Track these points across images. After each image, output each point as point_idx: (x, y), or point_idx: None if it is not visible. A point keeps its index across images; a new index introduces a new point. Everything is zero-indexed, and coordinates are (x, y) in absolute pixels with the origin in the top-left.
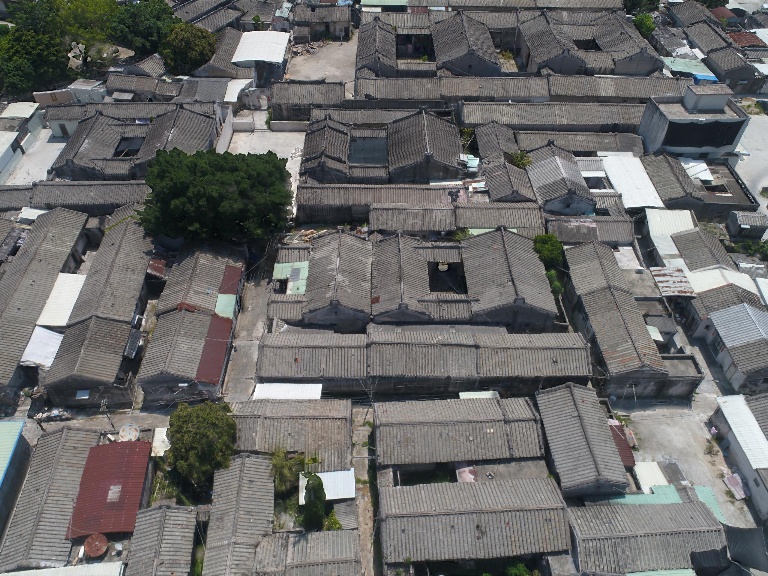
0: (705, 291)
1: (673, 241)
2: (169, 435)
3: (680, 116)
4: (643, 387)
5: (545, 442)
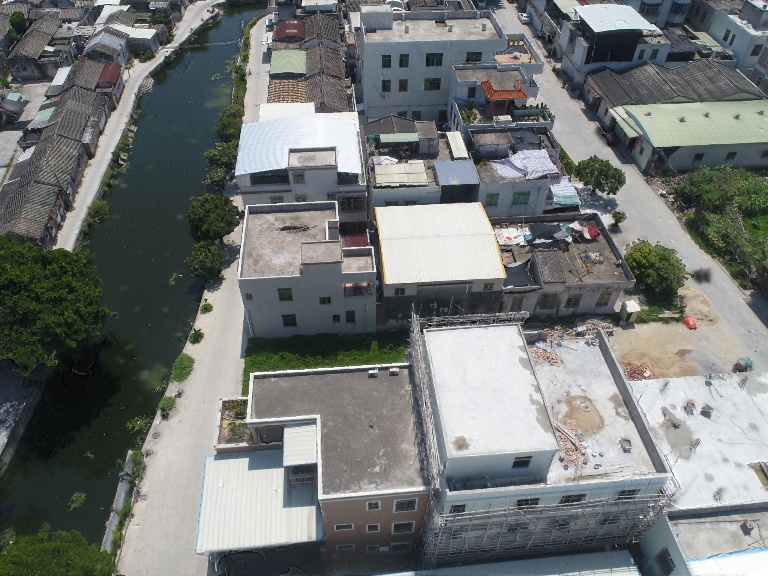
0: None
1: None
2: None
3: None
4: (31, 71)
5: None
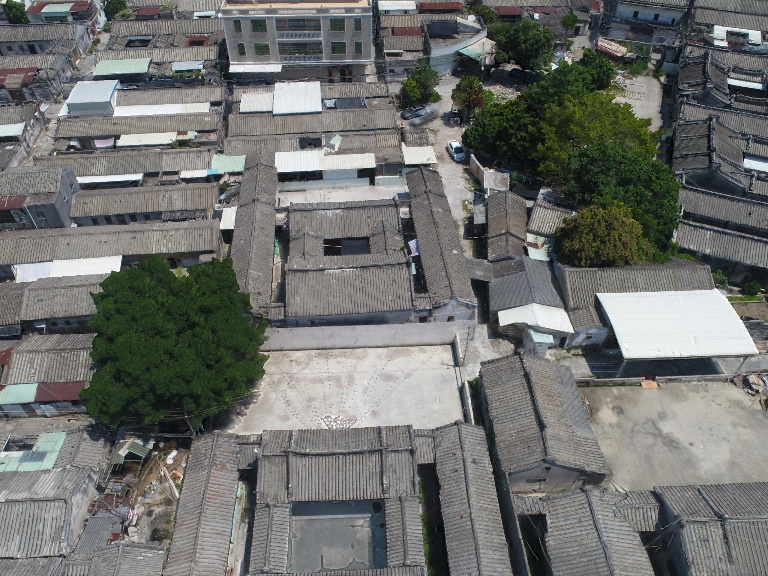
0: None
1: None
2: None
3: None
4: None
5: None
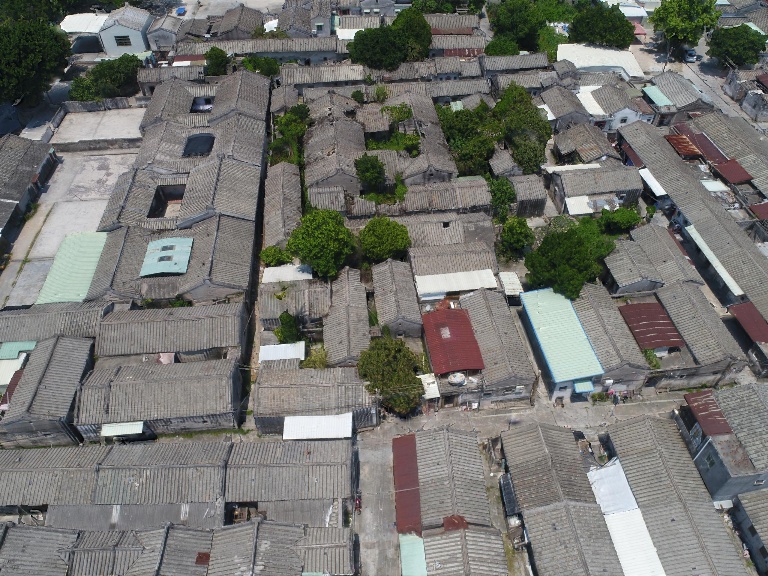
0: None
1: None
2: None
3: None
4: None
5: (84, 376)
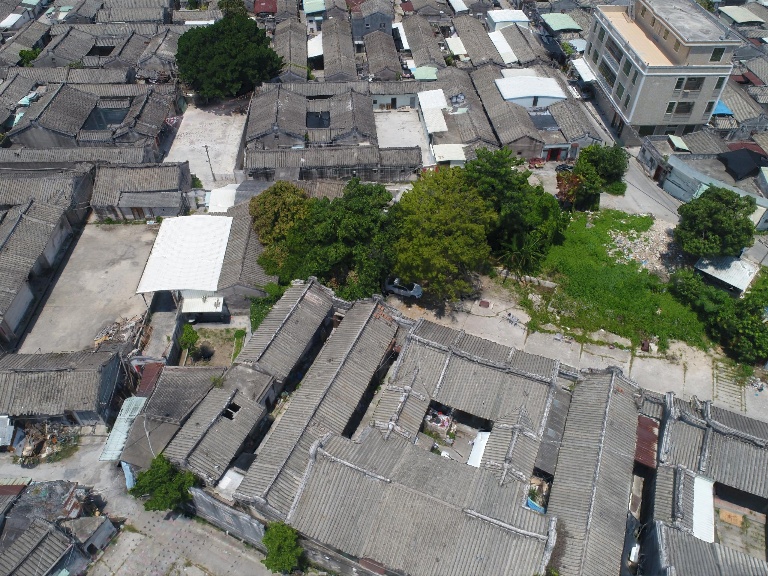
0: None
1: None
2: None
3: None
4: None
5: None
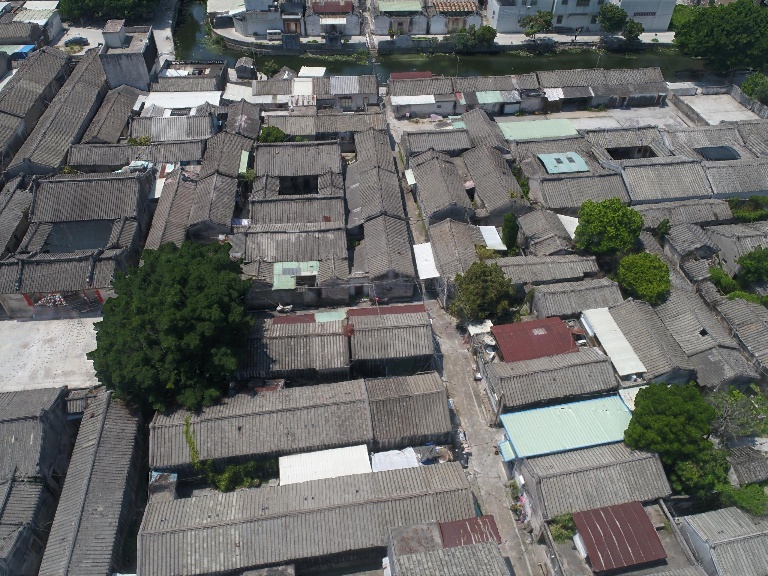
0: (313, 90)
1: (259, 95)
2: (496, 294)
3: (130, 51)
4: None
5: None
